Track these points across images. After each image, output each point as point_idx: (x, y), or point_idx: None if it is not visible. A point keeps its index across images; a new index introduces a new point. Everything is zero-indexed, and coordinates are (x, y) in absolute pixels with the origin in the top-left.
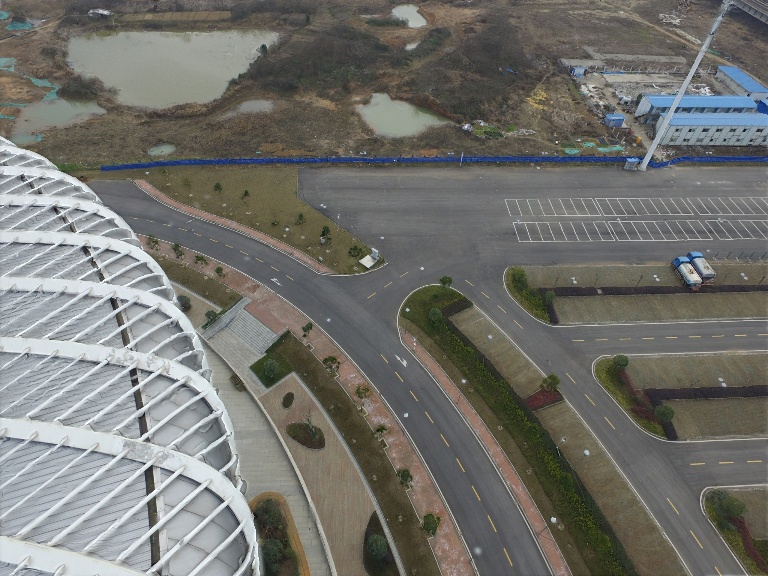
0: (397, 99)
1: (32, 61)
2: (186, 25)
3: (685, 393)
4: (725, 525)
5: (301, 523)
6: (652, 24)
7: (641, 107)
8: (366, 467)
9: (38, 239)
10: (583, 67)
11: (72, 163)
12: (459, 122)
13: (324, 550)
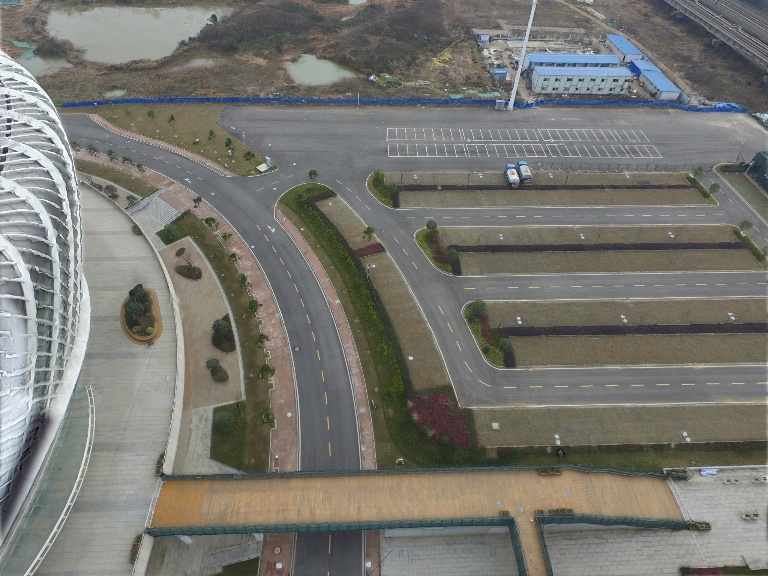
0: (321, 58)
1: (15, 28)
2: (153, 1)
3: (477, 248)
4: (471, 318)
5: (163, 304)
6: (567, 3)
7: (524, 64)
8: (228, 289)
9: None
10: (489, 35)
11: None
12: (369, 75)
13: (174, 314)
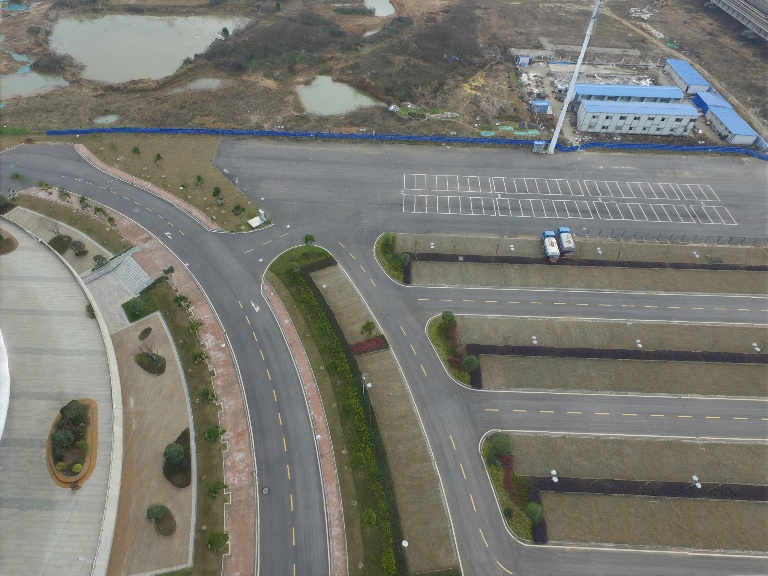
0: (338, 81)
1: (17, 38)
2: (165, 10)
3: (503, 349)
4: (491, 460)
5: (103, 424)
6: (620, 18)
7: None
8: (193, 392)
9: None
10: (529, 56)
11: (22, 127)
12: (389, 104)
13: (111, 444)
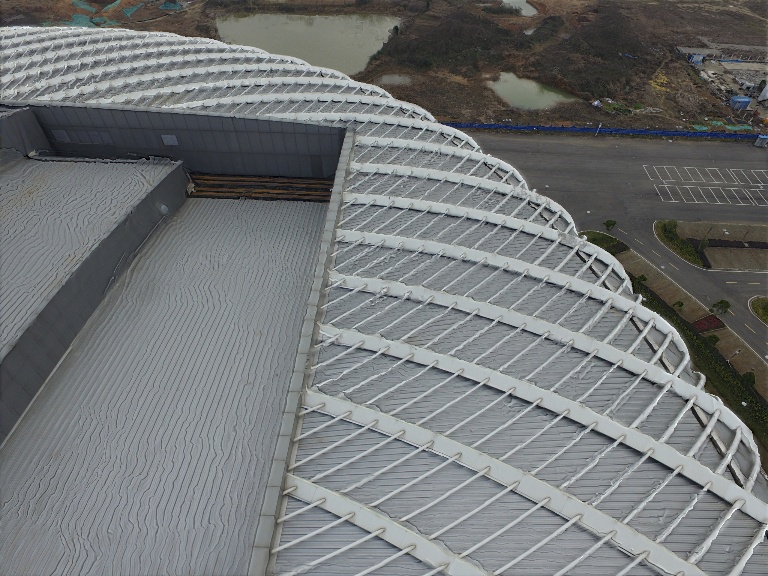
0: (524, 77)
1: None
2: (316, 9)
3: None
4: None
5: None
6: (764, 18)
7: (766, 91)
8: None
9: (411, 124)
10: (701, 55)
11: None
12: (587, 99)
13: None
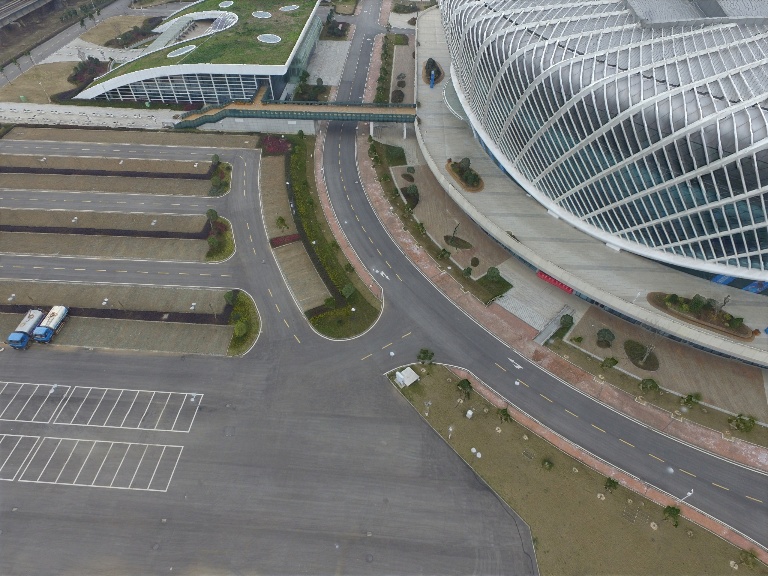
0: None
1: None
2: None
3: (180, 233)
4: None
5: (453, 182)
6: None
7: None
8: None
9: None
10: None
11: None
12: None
13: None
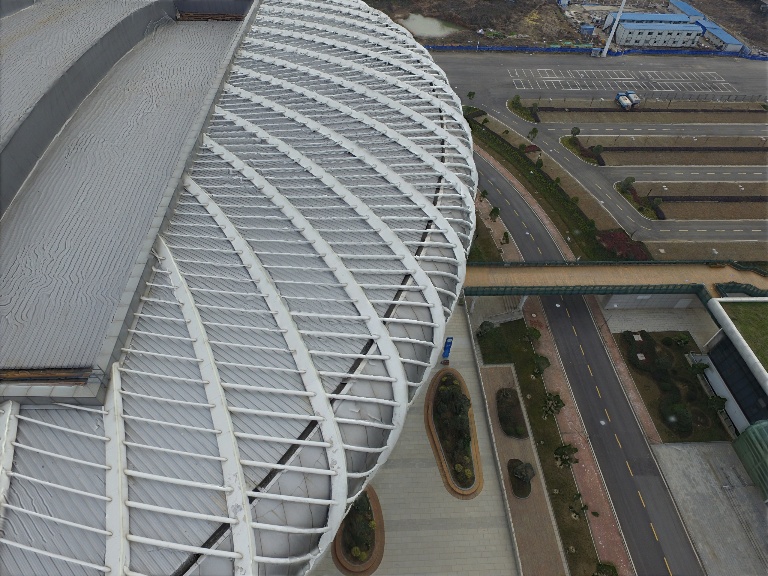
0: (428, 16)
1: None
2: None
3: (612, 148)
4: (624, 189)
5: None
6: None
7: (607, 22)
8: None
9: None
10: None
11: None
12: (475, 30)
13: None
